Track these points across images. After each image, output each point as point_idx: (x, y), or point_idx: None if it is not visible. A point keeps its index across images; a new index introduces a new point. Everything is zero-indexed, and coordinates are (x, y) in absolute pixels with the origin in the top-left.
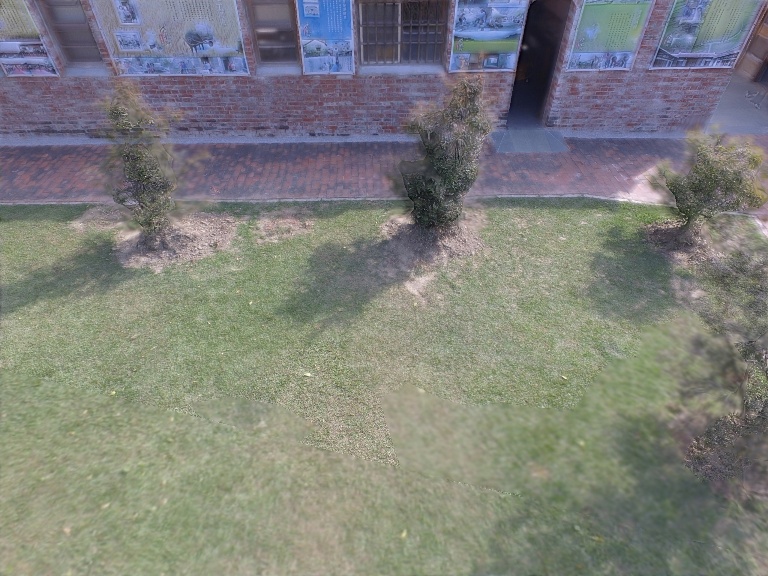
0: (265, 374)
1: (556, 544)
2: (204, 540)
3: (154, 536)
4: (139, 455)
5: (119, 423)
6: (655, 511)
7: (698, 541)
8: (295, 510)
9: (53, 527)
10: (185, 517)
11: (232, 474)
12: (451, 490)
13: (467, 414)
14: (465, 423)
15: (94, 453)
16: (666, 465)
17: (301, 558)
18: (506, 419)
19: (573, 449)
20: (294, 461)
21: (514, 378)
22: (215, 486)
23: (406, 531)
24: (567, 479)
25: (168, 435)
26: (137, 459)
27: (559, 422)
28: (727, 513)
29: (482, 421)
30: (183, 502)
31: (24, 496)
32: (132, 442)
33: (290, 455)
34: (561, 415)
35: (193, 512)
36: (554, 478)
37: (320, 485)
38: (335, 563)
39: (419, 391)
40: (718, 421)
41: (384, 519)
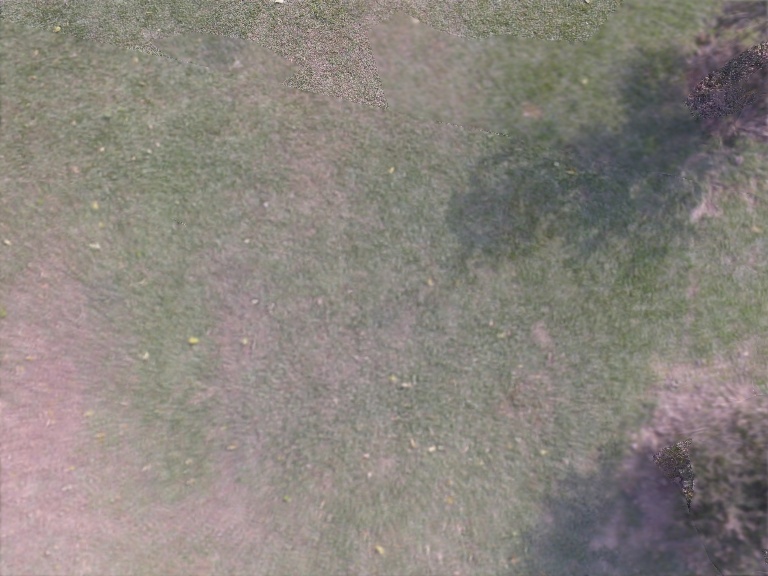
0: (229, 1)
1: (533, 178)
2: (205, 179)
3: (157, 176)
4: (115, 100)
5: (80, 65)
6: (637, 148)
7: (667, 174)
8: (286, 152)
9: (59, 169)
10: (181, 159)
11: (217, 118)
12: (439, 131)
13: (465, 49)
14: (462, 60)
15: (67, 99)
16: (666, 103)
17: (297, 192)
18: (508, 54)
19: (573, 88)
20: (278, 104)
21: (526, 2)
22: (203, 130)
23: (393, 169)
24: (559, 119)
25: (138, 78)
26: (114, 104)
27: (566, 57)
28: (706, 149)
29: (481, 57)
30: (175, 146)
31: (17, 142)
32: (102, 86)
33: (273, 98)
34: (570, 49)
35: (188, 155)
36: (546, 118)
37: (308, 128)
38: (329, 196)
39: (412, 21)
40: (744, 52)
41: (373, 158)
